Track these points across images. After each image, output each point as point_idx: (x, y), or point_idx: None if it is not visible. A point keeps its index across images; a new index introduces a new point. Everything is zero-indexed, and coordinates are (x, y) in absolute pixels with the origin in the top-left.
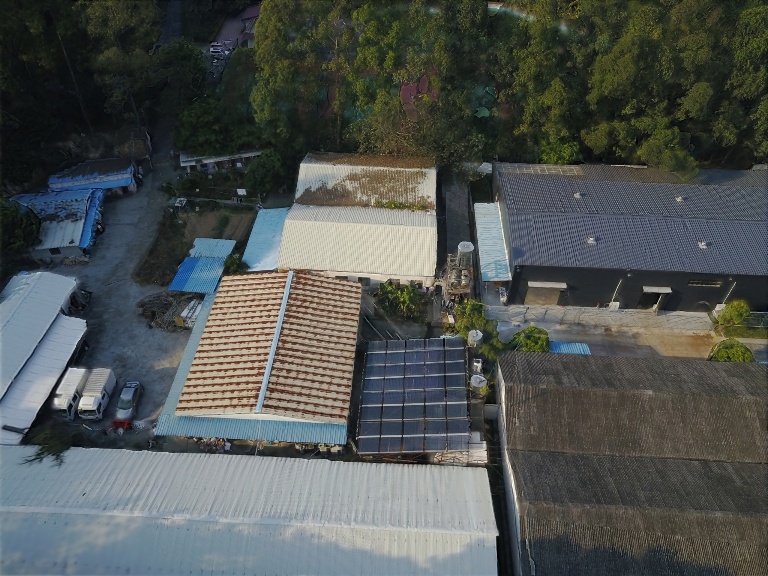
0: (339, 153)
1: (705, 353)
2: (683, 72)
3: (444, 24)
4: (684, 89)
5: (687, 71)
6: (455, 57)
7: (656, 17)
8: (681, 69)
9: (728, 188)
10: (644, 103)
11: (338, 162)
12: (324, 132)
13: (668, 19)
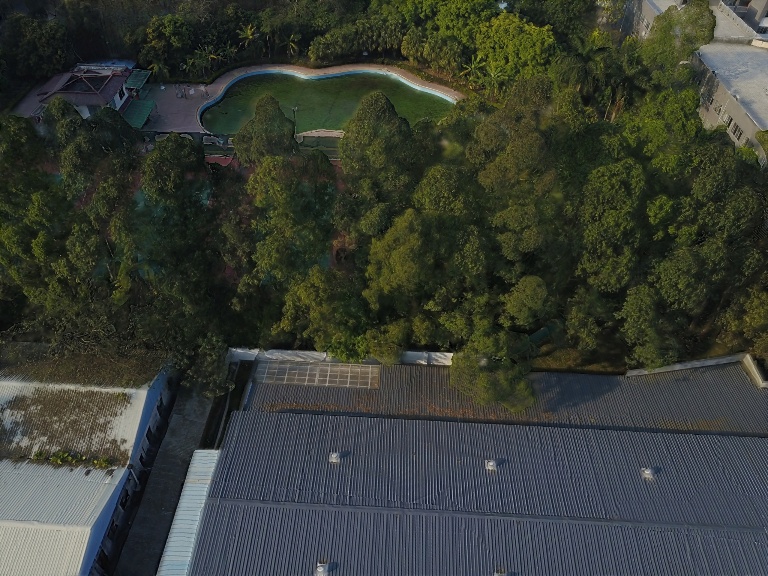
0: (34, 344)
1: None
2: (503, 261)
3: (117, 196)
4: (508, 283)
5: (508, 260)
6: (166, 229)
7: (451, 186)
8: (499, 257)
9: (572, 434)
10: (454, 296)
11: (9, 372)
12: (4, 318)
13: (476, 184)
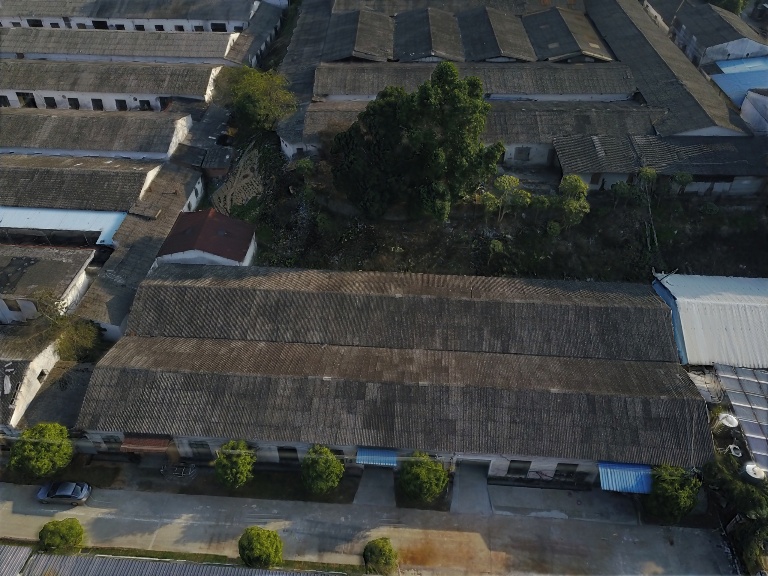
0: None
1: (419, 537)
2: None
3: None
4: None
5: None
6: None
7: None
8: None
9: None
10: None
11: None
12: None
13: None
